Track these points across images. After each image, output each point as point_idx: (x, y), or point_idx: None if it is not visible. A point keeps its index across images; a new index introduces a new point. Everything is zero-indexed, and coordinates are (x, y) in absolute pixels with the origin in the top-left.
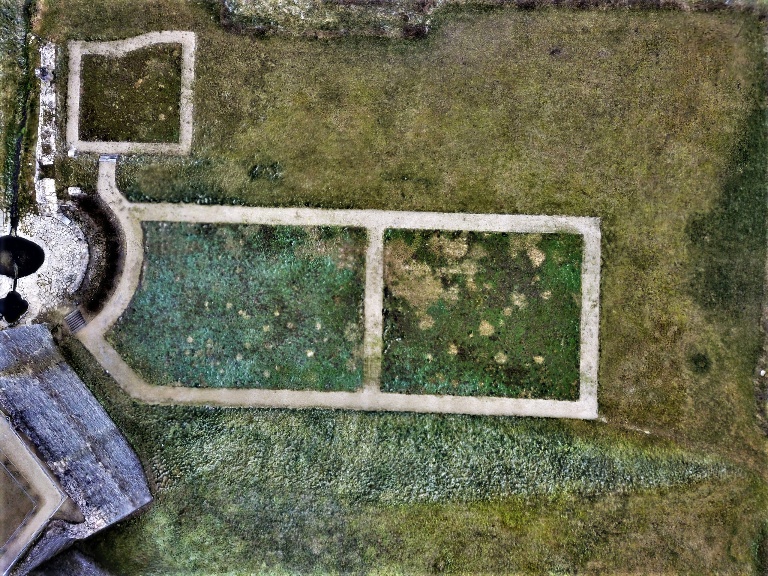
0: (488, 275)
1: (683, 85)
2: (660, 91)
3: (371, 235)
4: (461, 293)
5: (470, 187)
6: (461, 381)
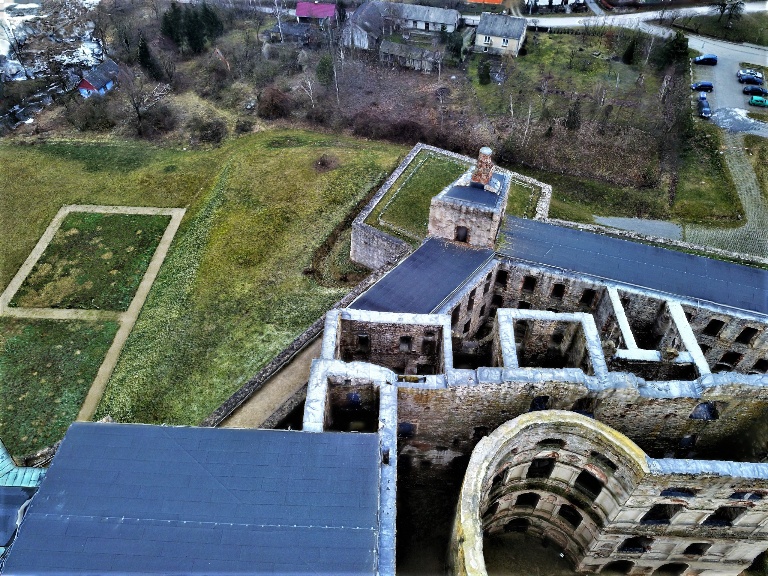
0: (72, 254)
1: (5, 172)
2: (3, 181)
3: (8, 314)
4: (77, 267)
5: (6, 261)
6: (137, 269)
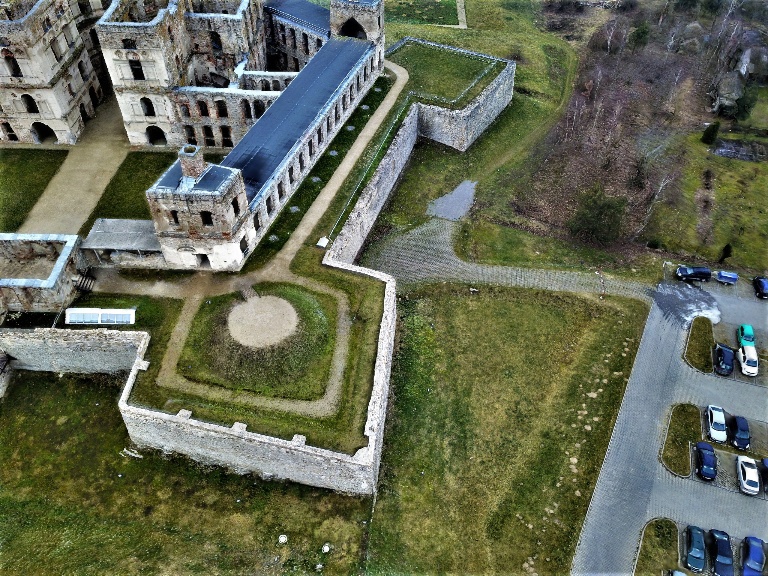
0: None
1: None
2: None
3: None
4: None
5: None
6: (408, 21)
